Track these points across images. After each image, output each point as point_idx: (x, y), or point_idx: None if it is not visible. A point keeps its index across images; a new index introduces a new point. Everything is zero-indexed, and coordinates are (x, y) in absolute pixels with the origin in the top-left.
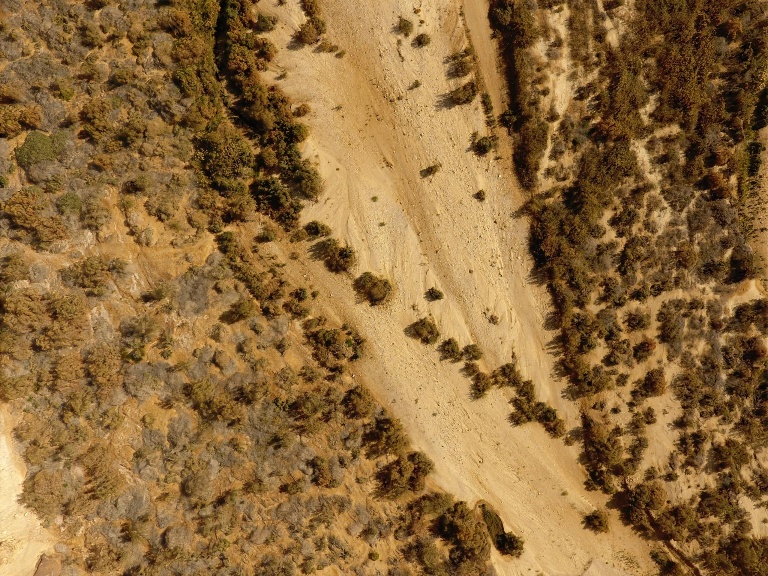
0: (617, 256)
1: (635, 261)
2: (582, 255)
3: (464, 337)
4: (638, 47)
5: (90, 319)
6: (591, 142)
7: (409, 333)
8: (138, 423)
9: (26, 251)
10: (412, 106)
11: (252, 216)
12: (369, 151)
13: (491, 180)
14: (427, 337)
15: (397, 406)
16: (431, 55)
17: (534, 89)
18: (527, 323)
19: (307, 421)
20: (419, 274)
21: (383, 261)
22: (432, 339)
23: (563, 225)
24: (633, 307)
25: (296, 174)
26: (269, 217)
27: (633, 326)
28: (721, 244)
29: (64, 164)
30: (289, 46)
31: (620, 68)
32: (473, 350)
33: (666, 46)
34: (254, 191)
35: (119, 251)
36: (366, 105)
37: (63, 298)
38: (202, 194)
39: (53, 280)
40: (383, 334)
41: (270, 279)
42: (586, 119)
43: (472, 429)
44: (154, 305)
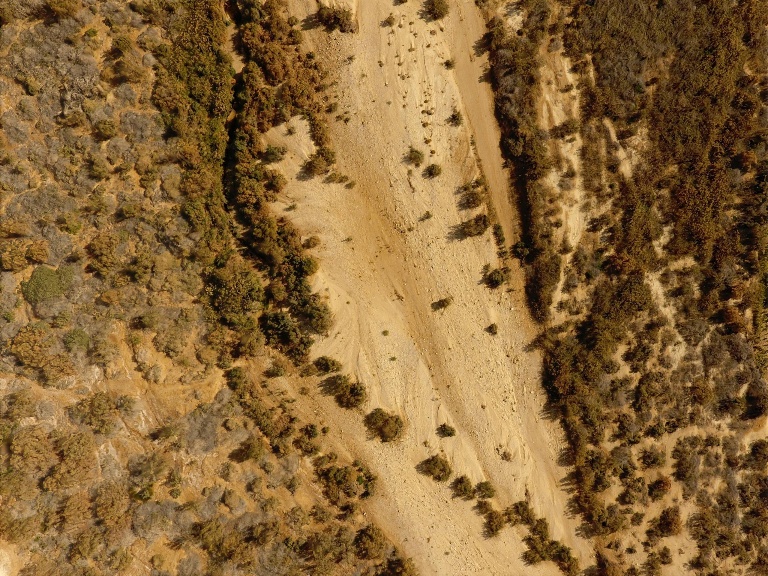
0: (631, 392)
1: (650, 398)
2: (596, 392)
3: (477, 474)
4: (651, 178)
5: (98, 457)
6: (604, 275)
7: (421, 470)
8: (146, 564)
9: (33, 387)
10: (423, 238)
11: (261, 351)
12: (380, 283)
13: (503, 313)
14: (439, 475)
15: (409, 545)
16: (442, 186)
17: (546, 221)
18: (540, 459)
19: (318, 562)
20: (431, 410)
21: (394, 396)
22: (444, 477)
23: (577, 362)
24: (648, 444)
25: (306, 308)
26: (279, 351)
27: (648, 464)
28: (737, 380)
29: (71, 300)
30: (298, 176)
31: (634, 201)
32: (486, 488)
33: (680, 178)
34: (263, 325)
35: (127, 388)
36: (376, 236)
37: (70, 437)
38: (211, 330)
39: (60, 417)
40: (394, 471)
41: (280, 414)
42: (599, 251)
43: (485, 568)
44: (162, 443)
